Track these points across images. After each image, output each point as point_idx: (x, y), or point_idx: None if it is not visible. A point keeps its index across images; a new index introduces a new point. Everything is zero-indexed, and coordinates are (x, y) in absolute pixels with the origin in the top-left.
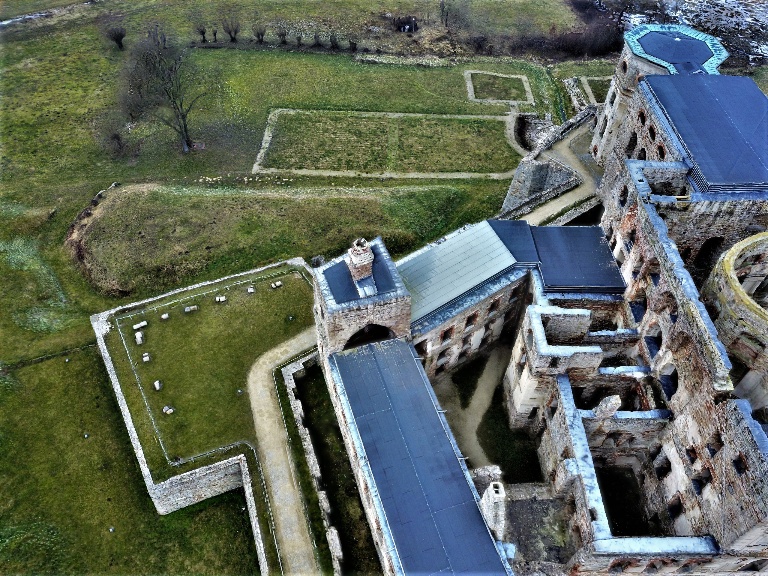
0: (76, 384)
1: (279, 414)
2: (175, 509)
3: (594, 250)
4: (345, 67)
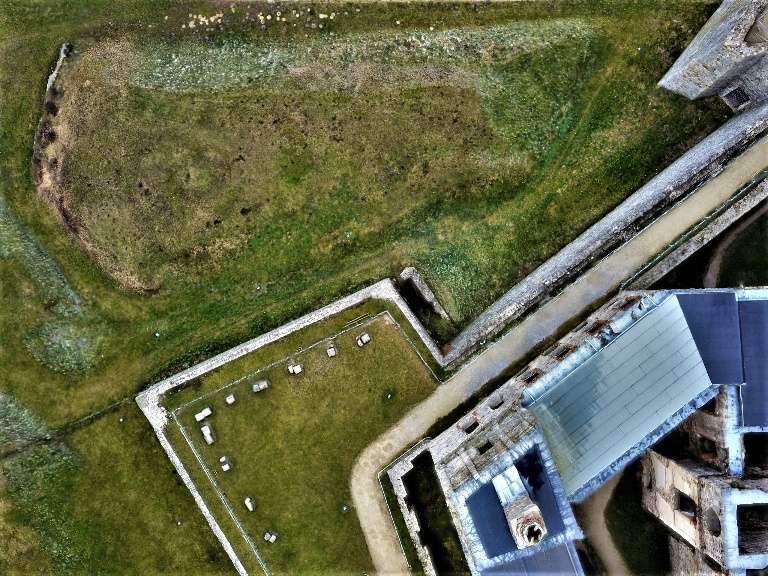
0: (144, 455)
1: (394, 536)
2: None
3: None
4: None
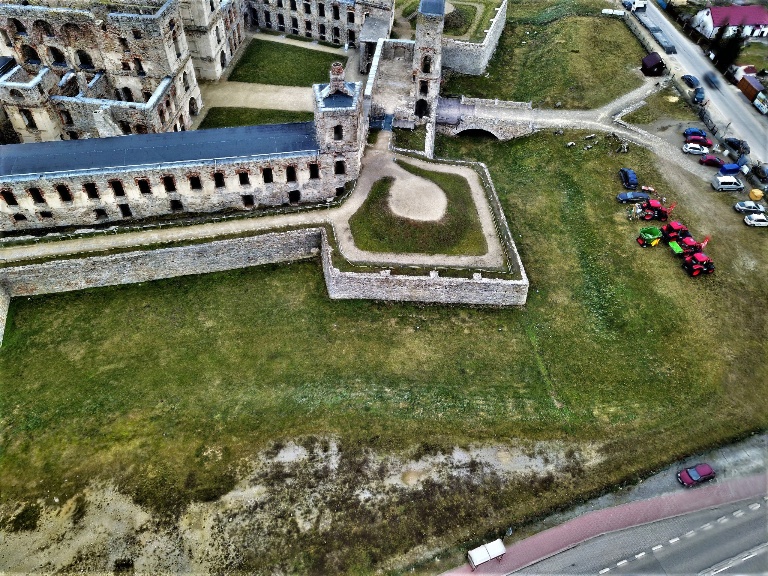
0: None
1: None
2: (1, 338)
3: None
4: None
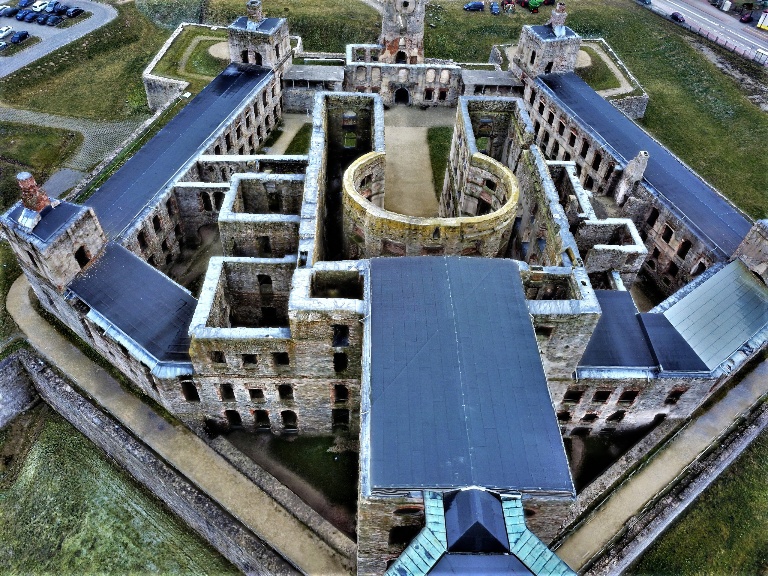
0: None
1: None
2: None
3: None
4: None
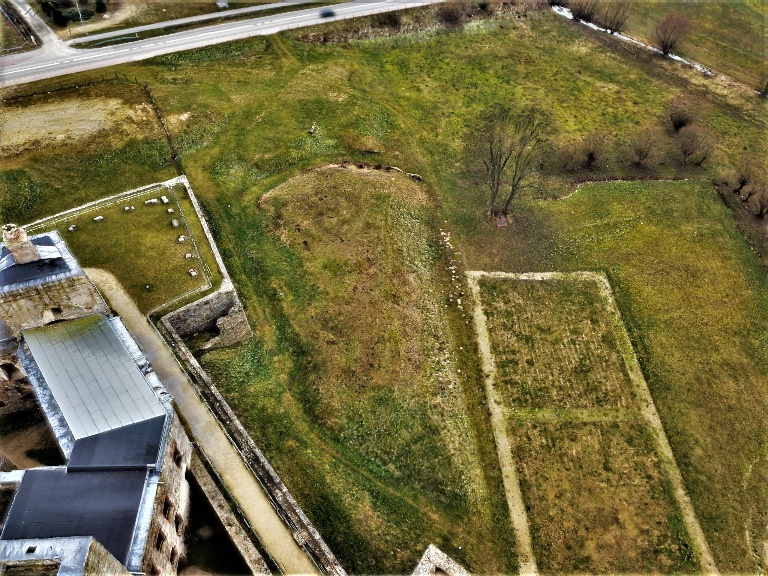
0: None
1: None
2: None
3: None
4: (760, 342)
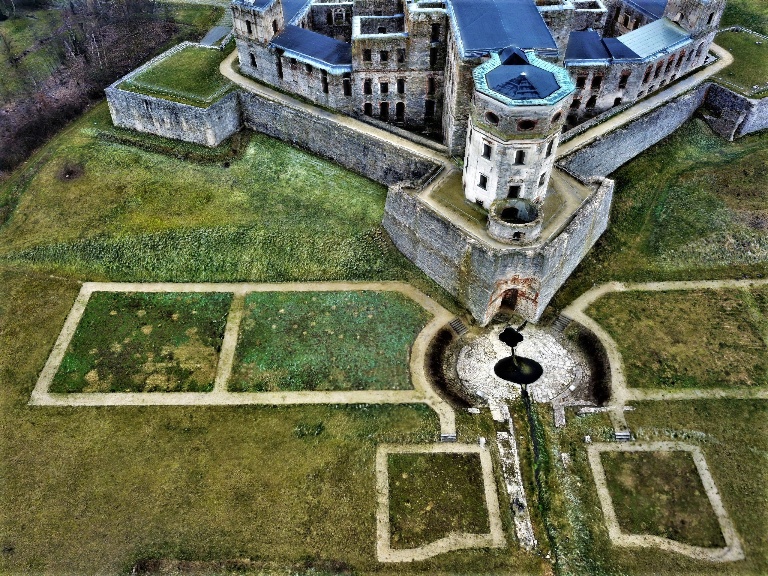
0: None
1: None
2: None
3: (568, 47)
4: None
